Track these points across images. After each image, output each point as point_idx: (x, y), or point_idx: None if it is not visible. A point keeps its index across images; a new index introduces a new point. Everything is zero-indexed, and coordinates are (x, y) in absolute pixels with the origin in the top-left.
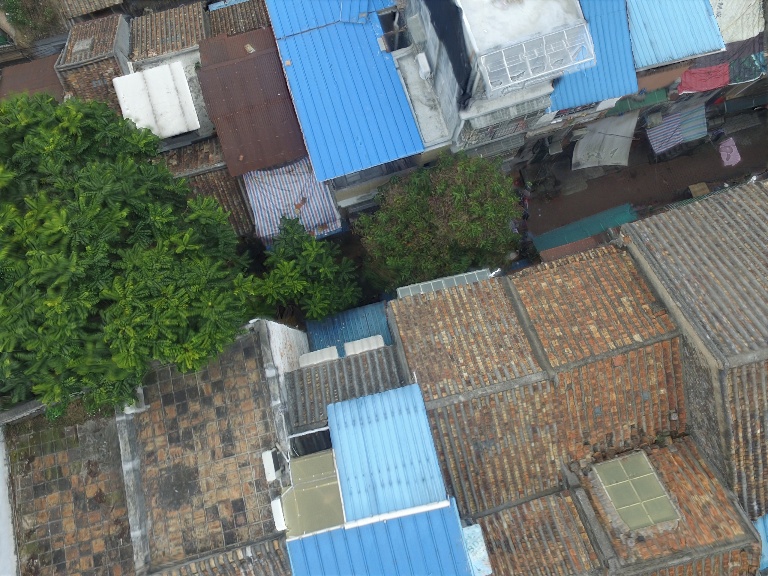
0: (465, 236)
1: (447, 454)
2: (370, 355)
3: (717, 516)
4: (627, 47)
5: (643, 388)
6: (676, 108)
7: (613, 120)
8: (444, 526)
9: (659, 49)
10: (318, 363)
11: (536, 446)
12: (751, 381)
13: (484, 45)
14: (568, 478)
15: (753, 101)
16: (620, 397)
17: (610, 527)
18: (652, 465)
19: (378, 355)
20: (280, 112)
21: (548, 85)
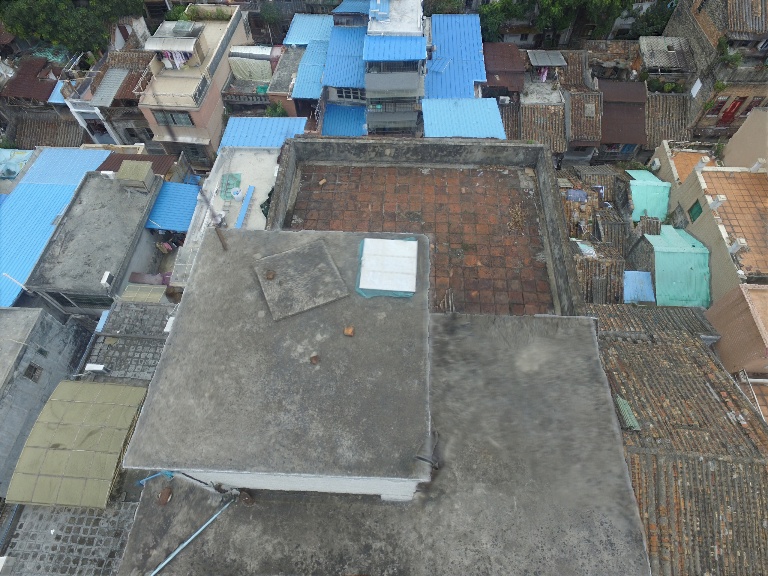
0: None
1: None
2: None
3: None
4: None
5: None
6: None
7: None
8: None
9: None
10: None
11: None
12: None
13: None
14: None
15: None
16: None
17: None
18: None
19: None
20: (488, 54)
21: None
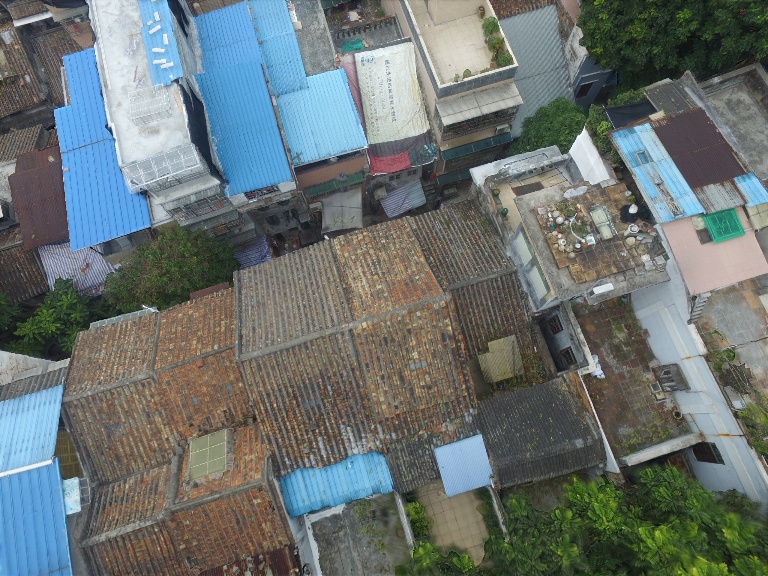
0: (155, 285)
1: (85, 435)
2: (60, 370)
3: (251, 468)
4: (281, 150)
5: (225, 383)
6: (398, 184)
7: (342, 195)
8: (48, 478)
9: (321, 149)
10: (24, 378)
11: (153, 428)
12: (262, 370)
13: (130, 160)
14: (176, 451)
15: (459, 176)
16: (209, 390)
17: (183, 480)
18: (227, 437)
19: (65, 370)
20: None
21: (214, 179)
